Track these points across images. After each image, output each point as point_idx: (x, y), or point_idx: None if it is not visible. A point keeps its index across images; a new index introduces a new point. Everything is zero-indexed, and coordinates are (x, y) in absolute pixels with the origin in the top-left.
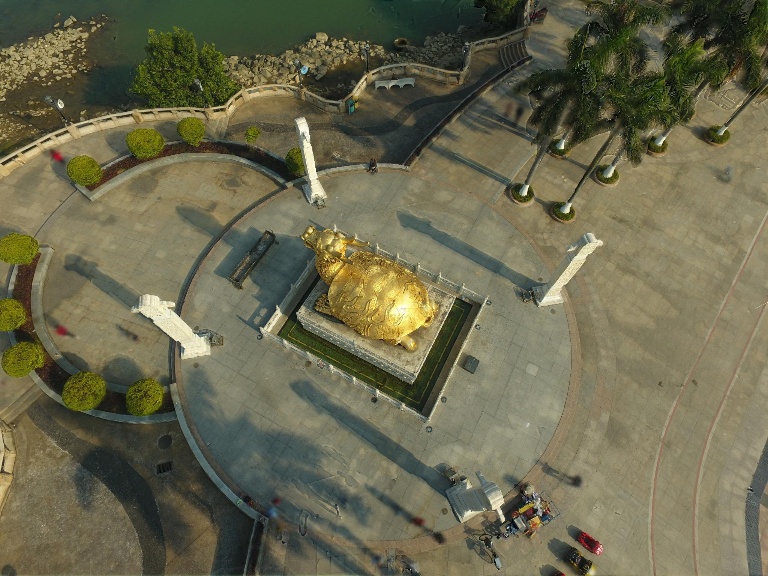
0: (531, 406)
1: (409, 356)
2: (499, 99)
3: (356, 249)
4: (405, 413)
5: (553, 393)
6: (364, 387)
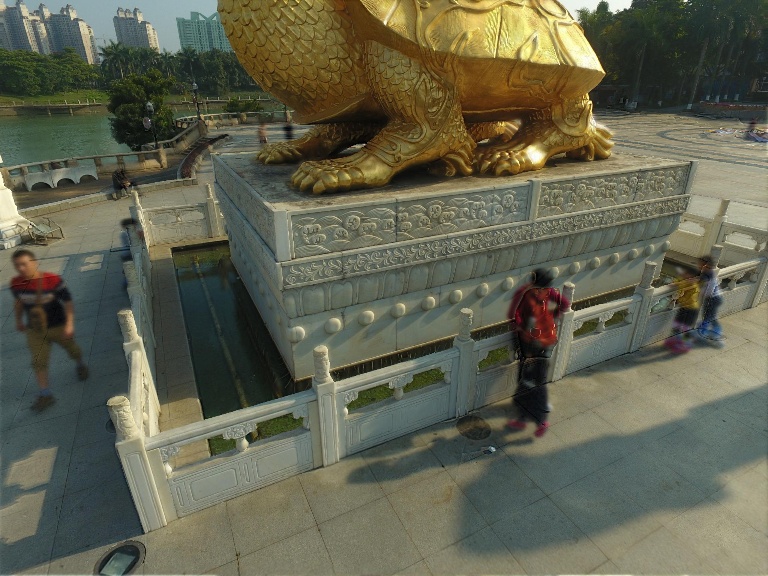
0: (733, 213)
1: (627, 160)
2: (232, 149)
3: (224, 238)
4: (766, 304)
5: (705, 201)
6: (670, 309)
